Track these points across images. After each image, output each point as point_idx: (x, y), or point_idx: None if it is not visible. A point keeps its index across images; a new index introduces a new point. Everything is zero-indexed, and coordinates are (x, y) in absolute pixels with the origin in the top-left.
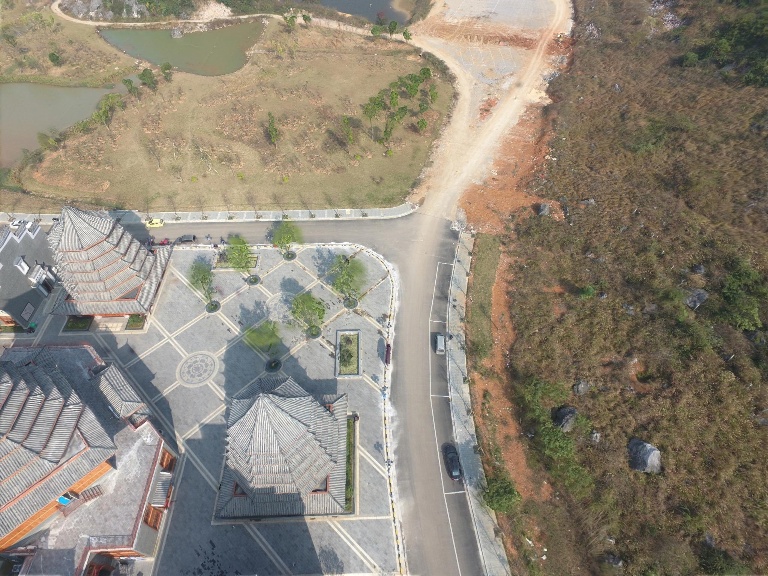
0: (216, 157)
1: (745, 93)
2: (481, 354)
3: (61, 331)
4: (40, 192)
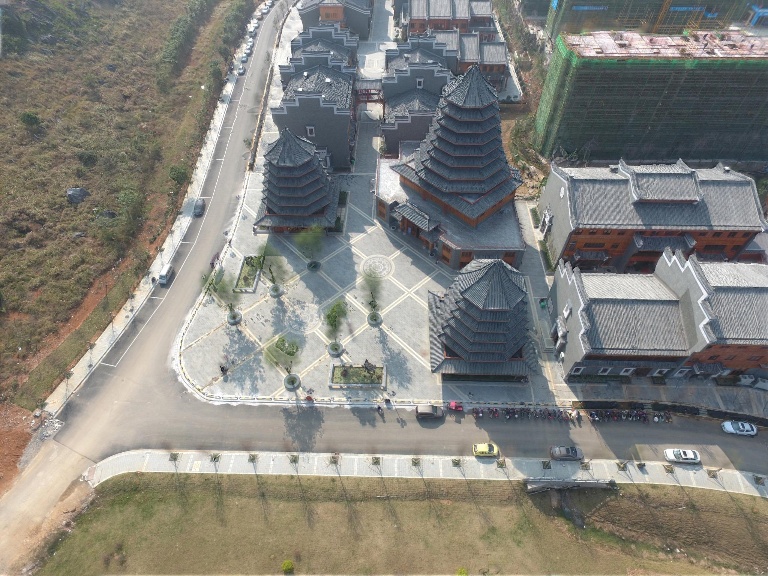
0: None
1: None
2: None
3: None
4: None
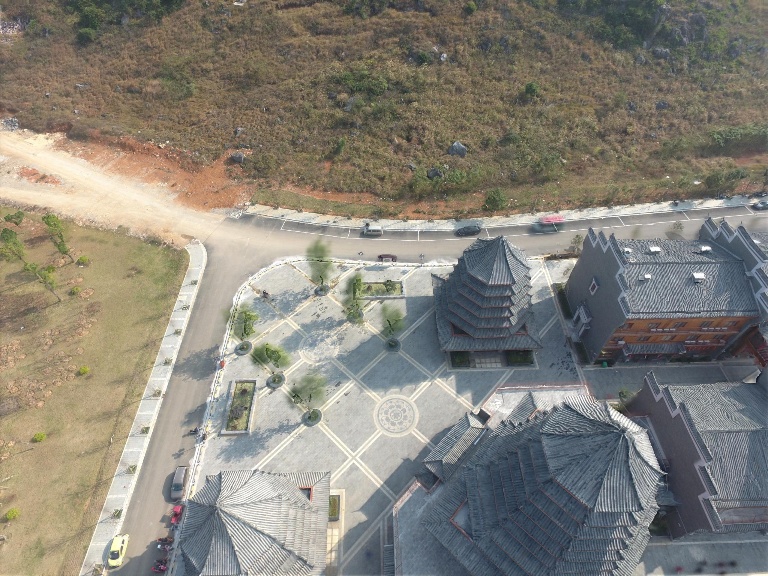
0: None
1: (169, 23)
2: (383, 211)
3: None
4: None
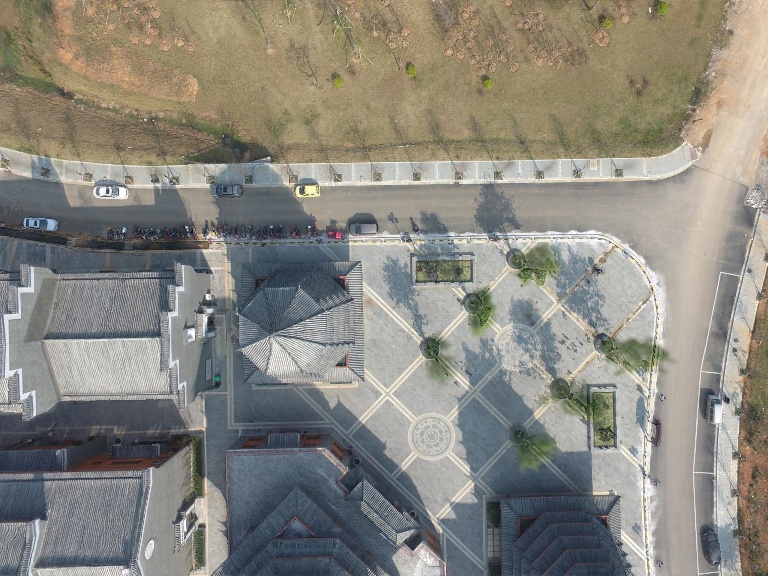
0: (359, 16)
1: None
2: (758, 423)
3: (254, 384)
4: (89, 95)
